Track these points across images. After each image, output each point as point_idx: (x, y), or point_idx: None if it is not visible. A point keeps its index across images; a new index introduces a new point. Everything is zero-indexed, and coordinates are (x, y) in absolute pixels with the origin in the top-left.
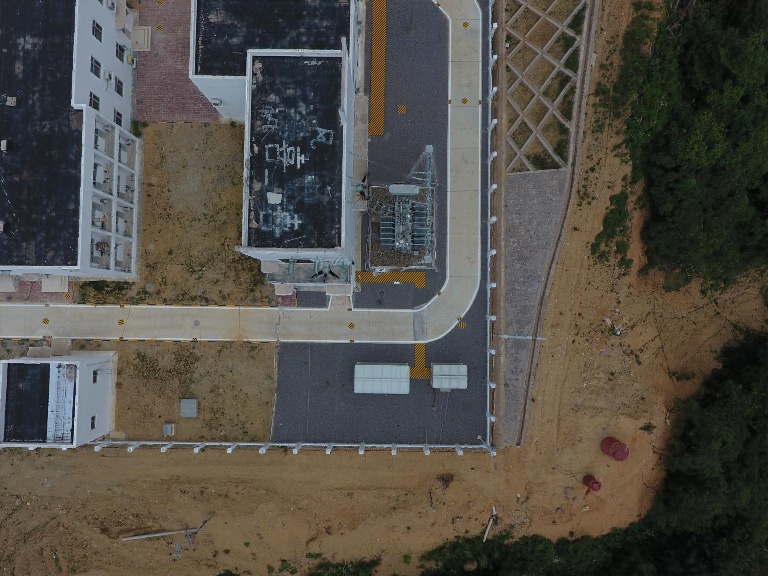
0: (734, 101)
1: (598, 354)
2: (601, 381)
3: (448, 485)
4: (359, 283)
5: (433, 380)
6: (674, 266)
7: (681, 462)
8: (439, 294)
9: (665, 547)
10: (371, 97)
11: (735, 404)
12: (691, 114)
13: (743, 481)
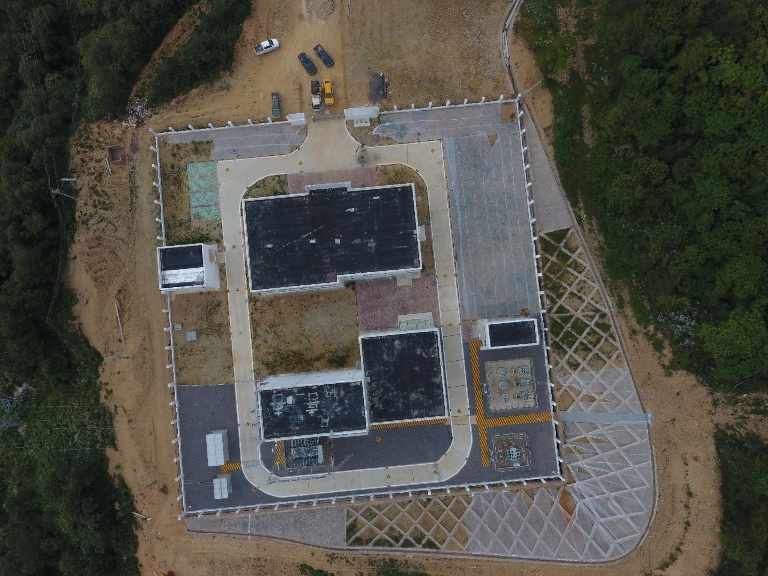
0: None
1: (247, 573)
2: (231, 575)
3: (161, 492)
4: None
5: (218, 479)
6: None
7: None
8: None
9: None
10: None
11: None
12: None
13: None
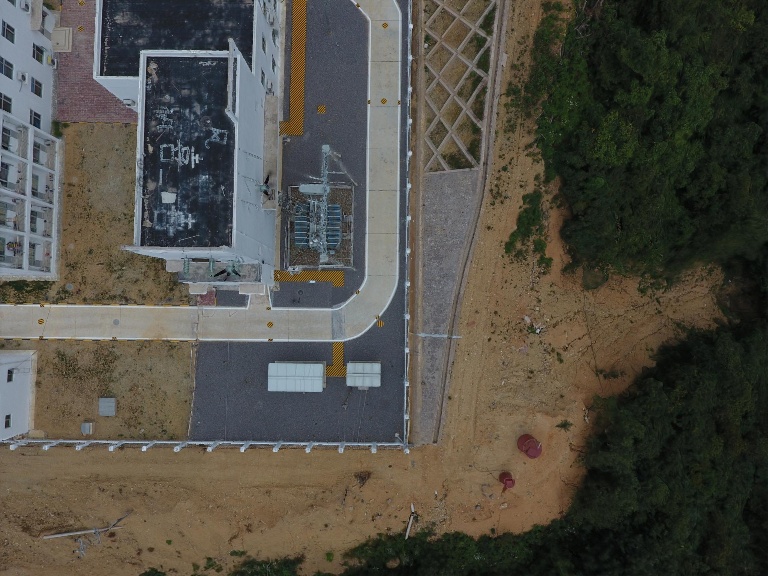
0: (643, 101)
1: (517, 352)
2: (520, 379)
3: (365, 483)
4: (278, 282)
5: (347, 378)
6: (593, 265)
7: (596, 459)
8: (357, 293)
9: (585, 544)
10: (291, 97)
11: (654, 402)
12: (603, 114)
13: (665, 478)
